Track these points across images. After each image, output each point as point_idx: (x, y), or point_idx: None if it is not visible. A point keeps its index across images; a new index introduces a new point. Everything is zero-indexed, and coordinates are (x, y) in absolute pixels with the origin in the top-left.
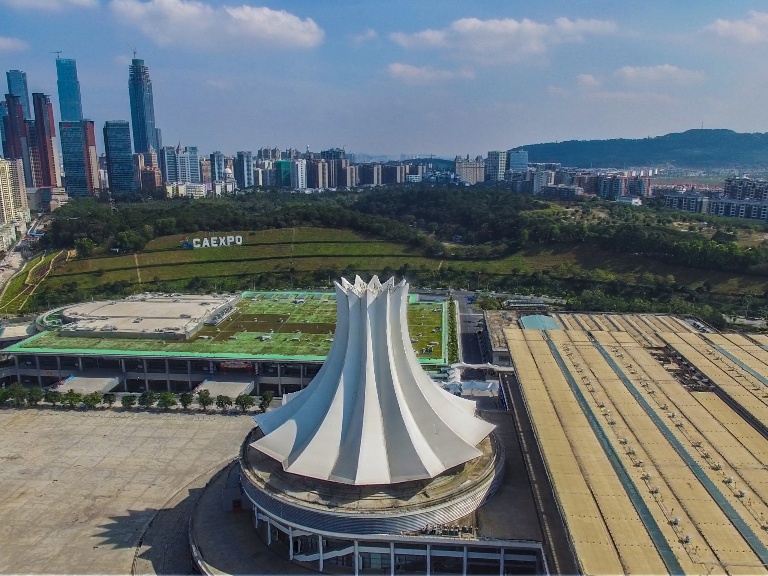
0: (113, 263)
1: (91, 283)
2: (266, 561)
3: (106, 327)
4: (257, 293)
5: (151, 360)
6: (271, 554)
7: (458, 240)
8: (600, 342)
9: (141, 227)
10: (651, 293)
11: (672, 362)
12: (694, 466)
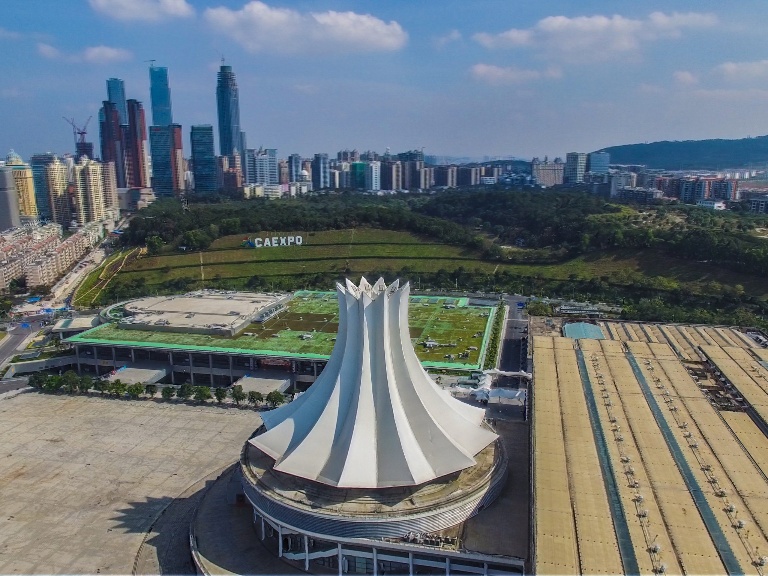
0: (180, 260)
1: (158, 279)
2: (256, 556)
3: (160, 321)
4: (309, 293)
5: (196, 354)
6: (263, 550)
7: (521, 244)
8: (634, 353)
9: (208, 226)
10: (717, 303)
11: (709, 378)
12: (696, 491)
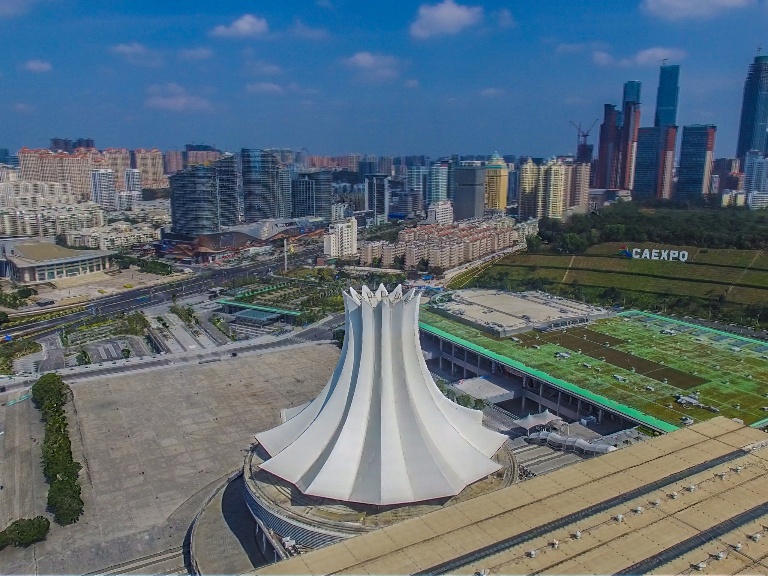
0: (551, 261)
1: (522, 276)
2: None
3: (457, 310)
4: (641, 314)
5: None
6: None
7: None
8: None
9: None
10: None
11: None
12: None
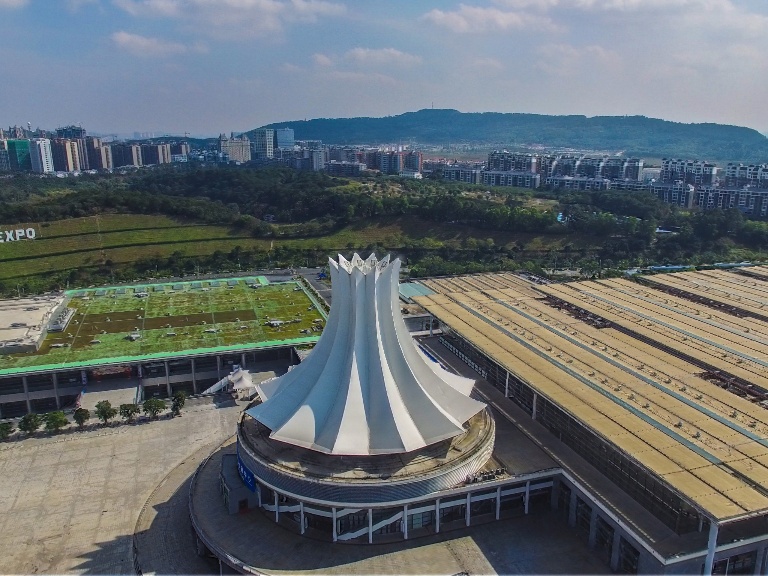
0: None
1: None
2: (312, 549)
3: None
4: (83, 291)
5: (2, 380)
6: (312, 541)
7: (271, 219)
8: (499, 299)
9: None
10: (476, 255)
11: (561, 308)
12: (654, 383)
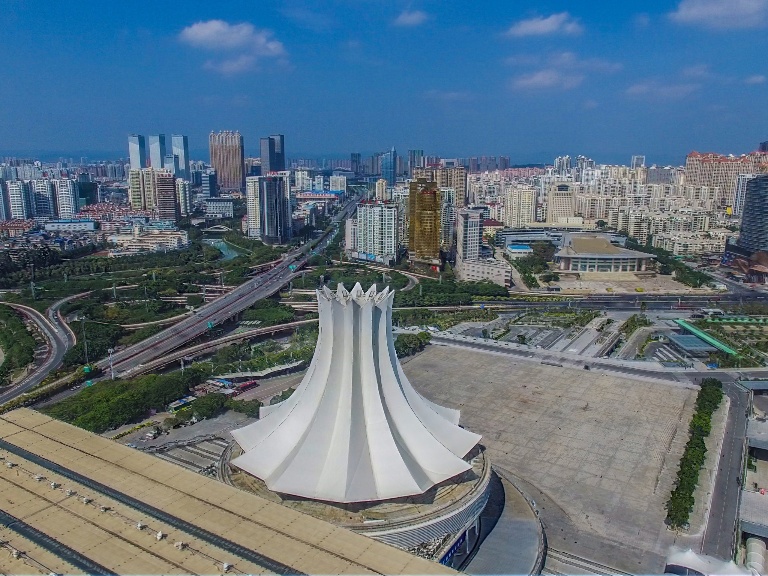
0: None
1: None
2: None
3: None
4: None
5: None
6: None
7: None
8: None
9: None
10: None
11: None
12: (13, 521)
